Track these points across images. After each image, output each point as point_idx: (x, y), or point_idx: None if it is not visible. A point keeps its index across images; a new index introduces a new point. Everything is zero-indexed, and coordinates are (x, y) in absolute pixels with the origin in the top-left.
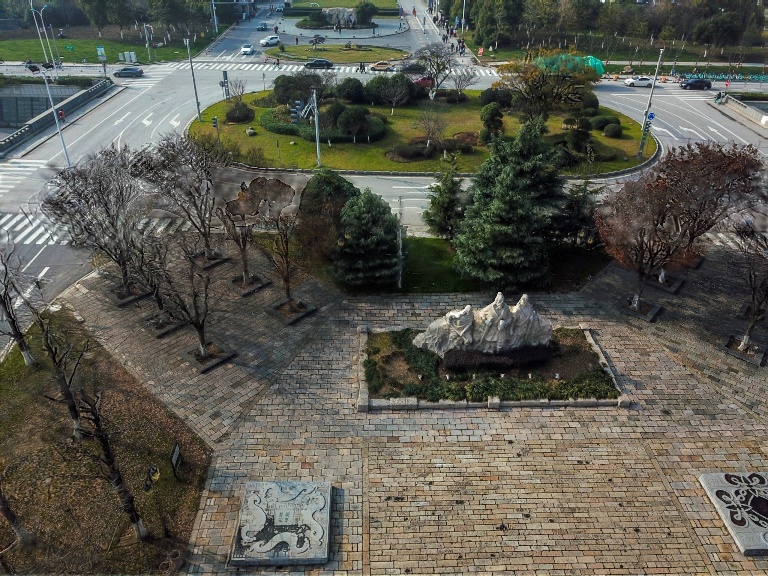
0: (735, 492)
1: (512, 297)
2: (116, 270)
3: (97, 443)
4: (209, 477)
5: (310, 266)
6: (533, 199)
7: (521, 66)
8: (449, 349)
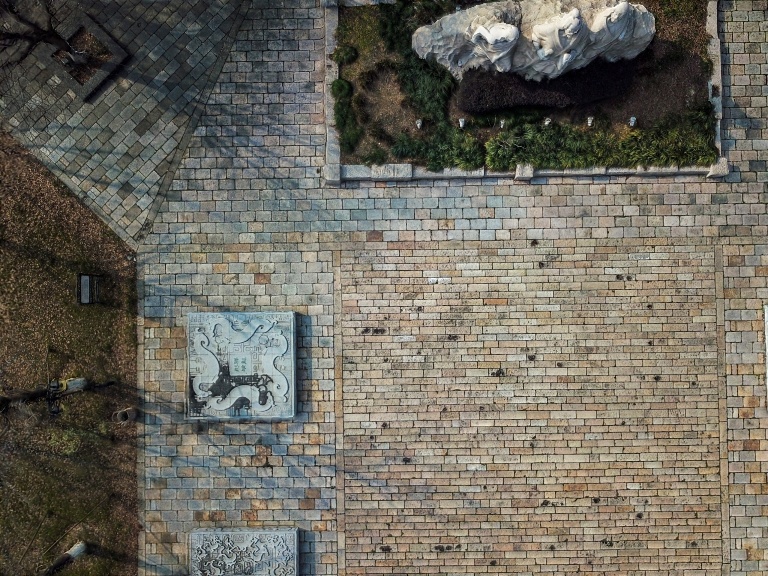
0: None
1: None
2: None
3: None
4: (139, 297)
5: None
6: None
7: None
8: (470, 68)
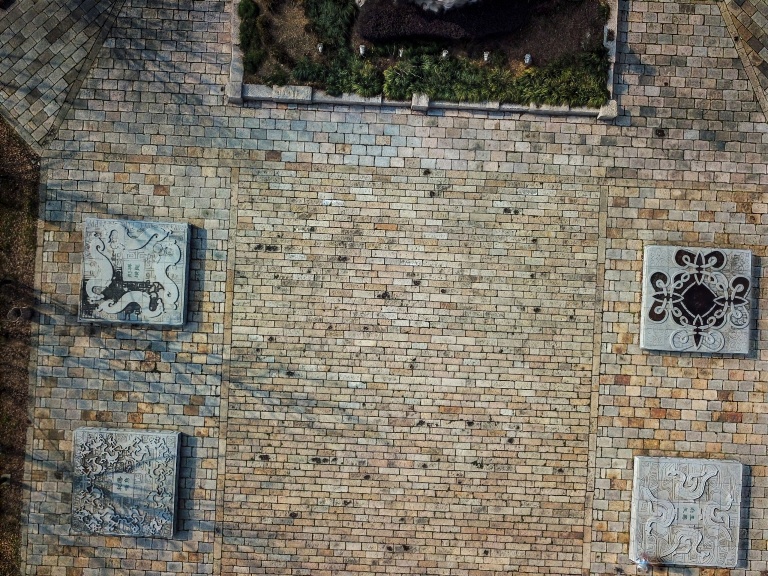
0: (676, 277)
1: None
2: None
3: None
4: (41, 200)
5: None
6: None
7: None
8: None
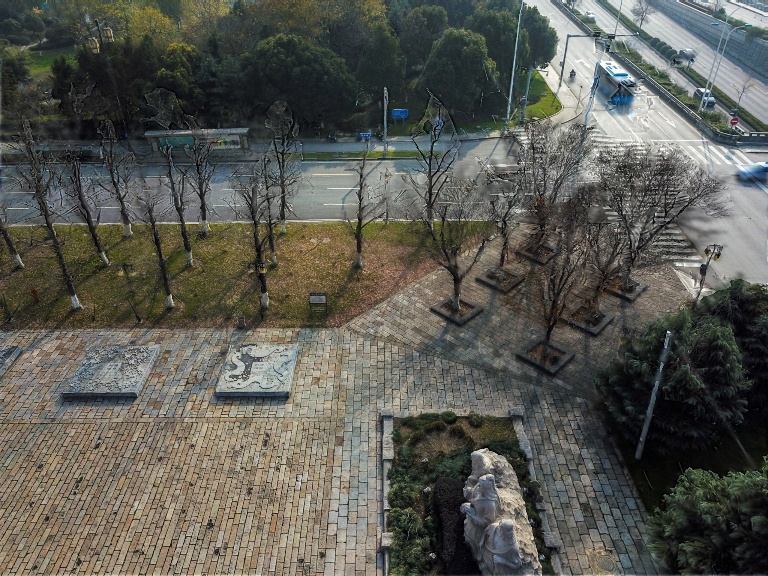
0: None
1: None
2: None
3: None
4: (312, 329)
5: None
6: None
7: None
8: None
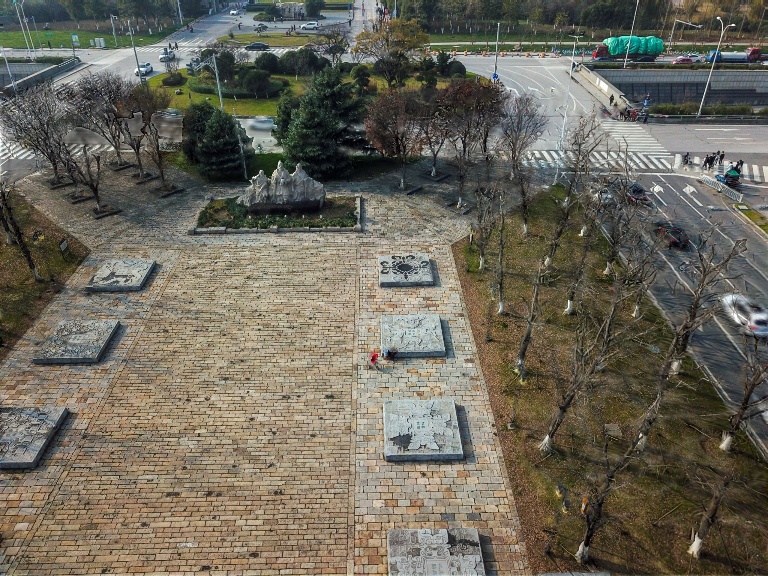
0: (392, 262)
1: (321, 183)
2: (53, 171)
3: (5, 210)
4: (85, 261)
5: (189, 168)
6: (334, 115)
7: (372, 34)
8: None
